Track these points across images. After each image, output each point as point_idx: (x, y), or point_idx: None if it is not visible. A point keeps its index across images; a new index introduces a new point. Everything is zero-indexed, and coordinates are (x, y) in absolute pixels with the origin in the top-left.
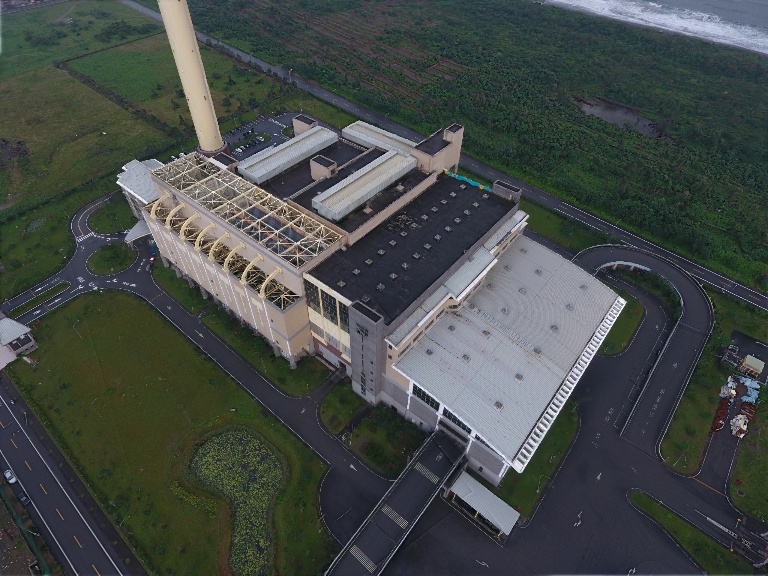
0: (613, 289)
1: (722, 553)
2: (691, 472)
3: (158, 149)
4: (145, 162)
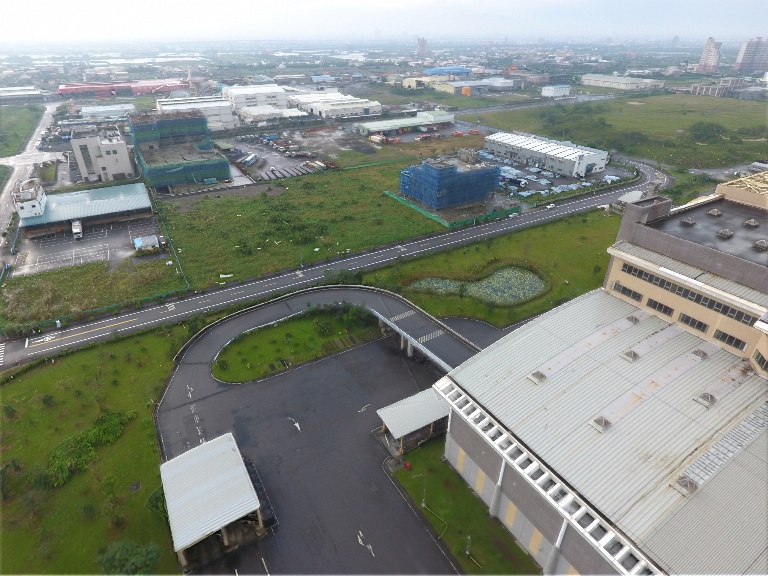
0: None
1: None
2: None
3: None
4: None
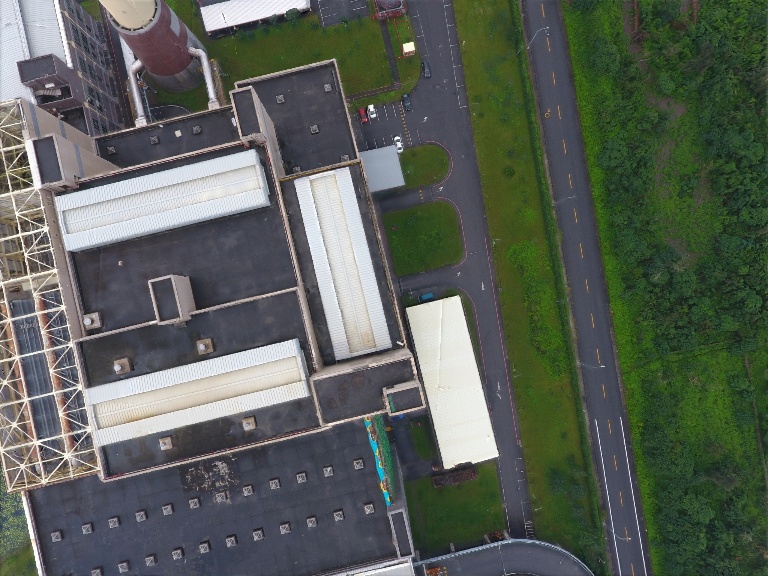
0: None
1: None
2: None
3: None
4: None
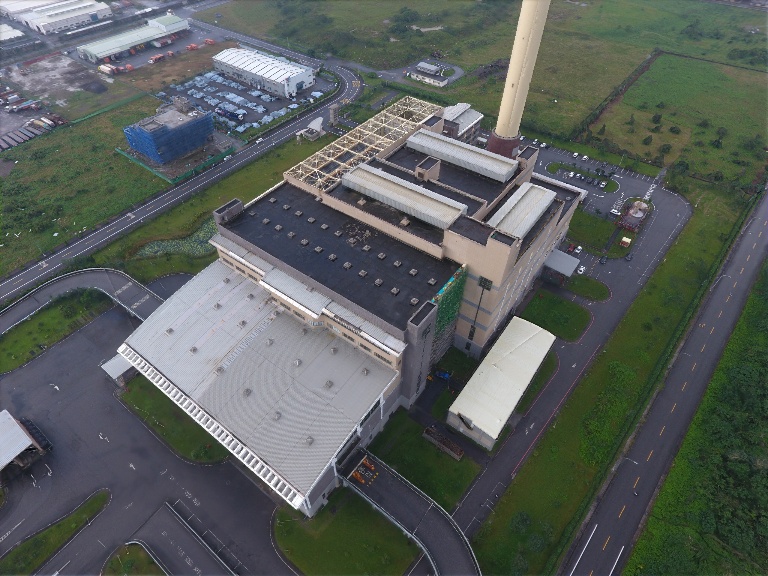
0: (396, 575)
1: (23, 570)
2: (105, 575)
3: (536, 127)
4: (474, 111)
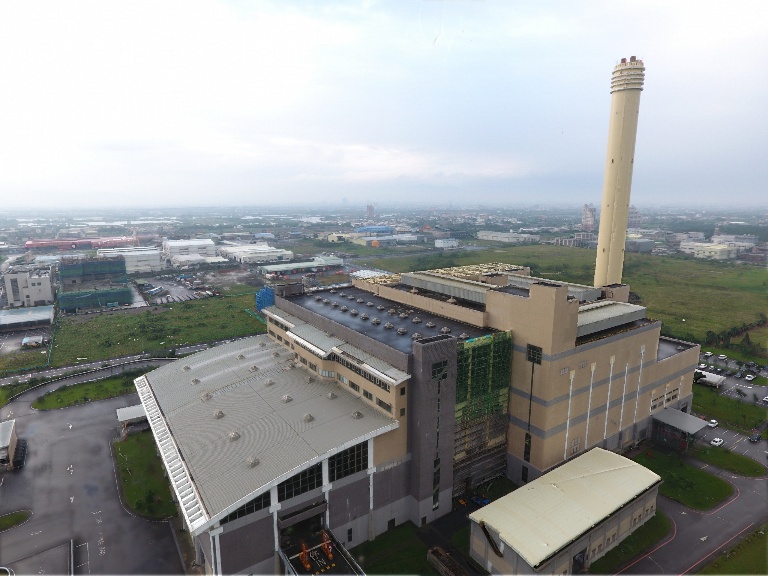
0: None
1: None
2: None
3: None
4: None
